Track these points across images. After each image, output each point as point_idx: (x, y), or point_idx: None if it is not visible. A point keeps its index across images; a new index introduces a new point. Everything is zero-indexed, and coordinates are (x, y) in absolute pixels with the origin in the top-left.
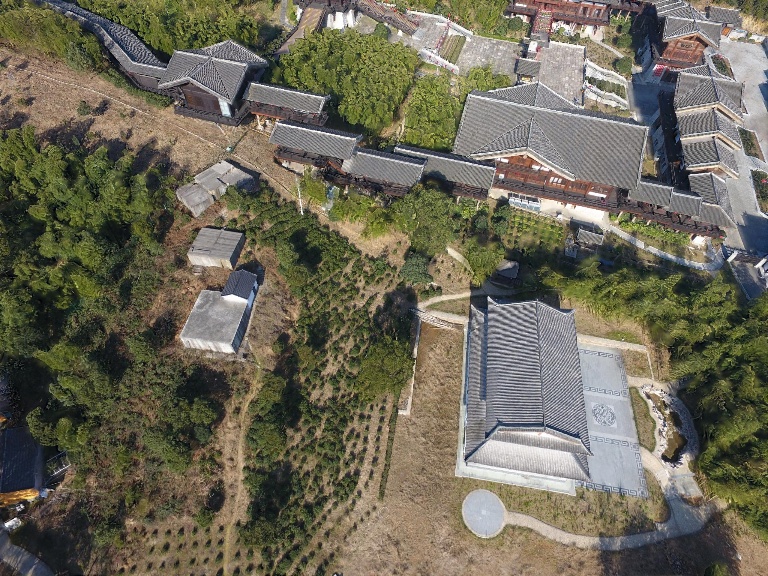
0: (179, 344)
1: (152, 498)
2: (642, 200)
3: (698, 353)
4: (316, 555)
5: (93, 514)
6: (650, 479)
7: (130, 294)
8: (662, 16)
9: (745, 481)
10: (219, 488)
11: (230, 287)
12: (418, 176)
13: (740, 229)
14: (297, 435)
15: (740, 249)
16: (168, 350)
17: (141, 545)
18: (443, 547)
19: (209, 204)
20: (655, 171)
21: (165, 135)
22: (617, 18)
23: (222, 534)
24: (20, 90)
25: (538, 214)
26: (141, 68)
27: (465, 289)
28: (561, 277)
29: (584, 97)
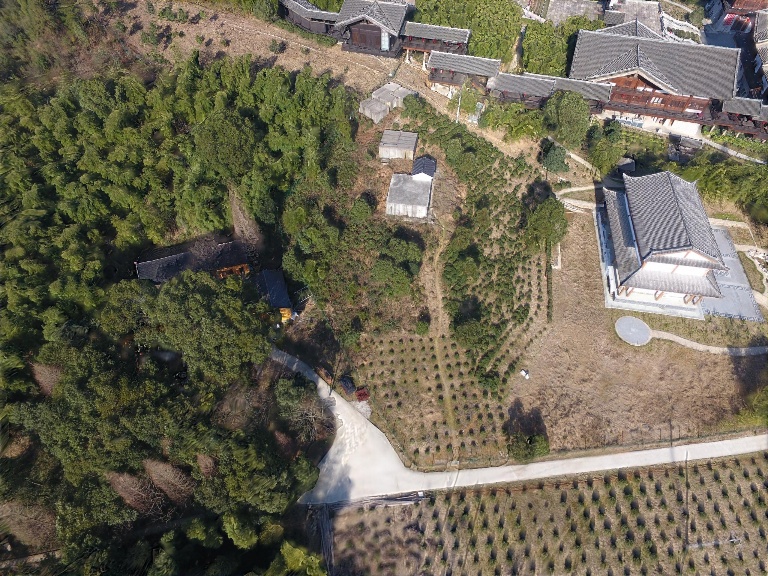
0: (381, 212)
1: (377, 318)
2: (735, 111)
3: None
4: (506, 357)
5: (334, 328)
6: (763, 311)
7: (336, 178)
8: None
9: None
10: (426, 311)
11: (418, 169)
12: (552, 89)
13: None
14: None
15: None
16: (374, 216)
17: (373, 350)
18: (604, 353)
19: (386, 114)
20: None
21: (337, 66)
22: None
23: (432, 343)
24: (218, 35)
25: (642, 129)
26: (315, 14)
27: (589, 183)
28: (676, 166)
29: None
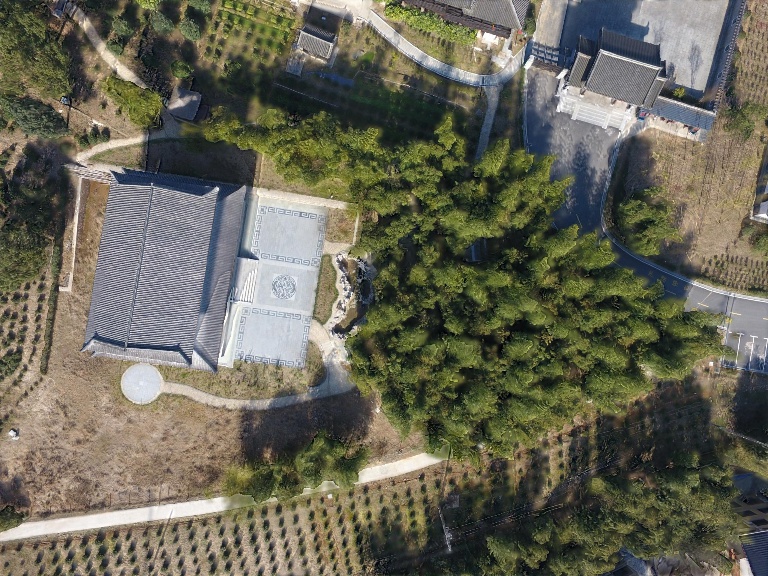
0: None
1: None
2: None
3: (383, 229)
4: None
5: None
6: (312, 350)
7: None
8: None
9: (365, 372)
10: None
11: None
12: None
13: (570, 9)
14: None
15: (552, 46)
16: None
17: None
18: (105, 410)
19: None
20: None
21: None
22: None
23: None
24: None
25: None
26: None
27: (141, 130)
28: (235, 126)
29: None
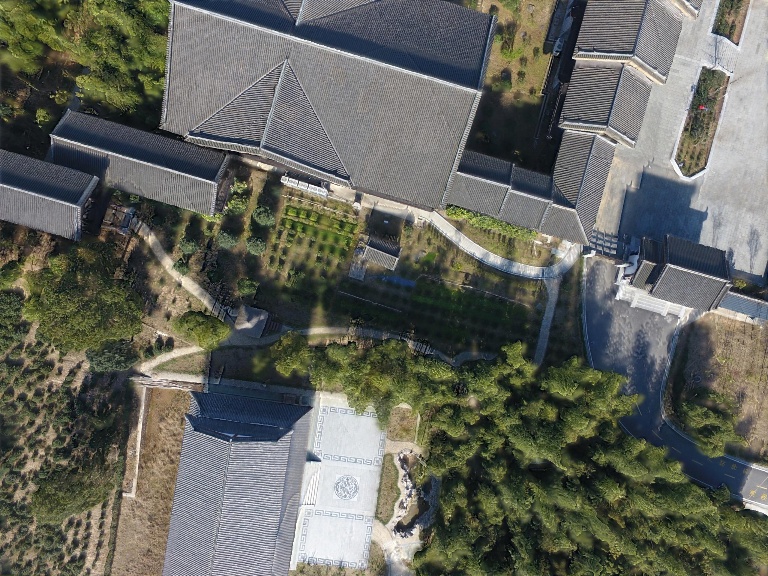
0: None
1: None
2: (461, 204)
3: (451, 448)
4: None
5: None
6: (375, 550)
7: None
8: None
9: None
10: None
11: None
12: (76, 222)
13: (628, 196)
14: (8, 533)
15: (611, 234)
16: None
17: None
18: None
19: None
20: (544, 81)
21: None
22: None
23: None
24: None
25: (321, 206)
26: None
27: None
28: (305, 355)
29: None
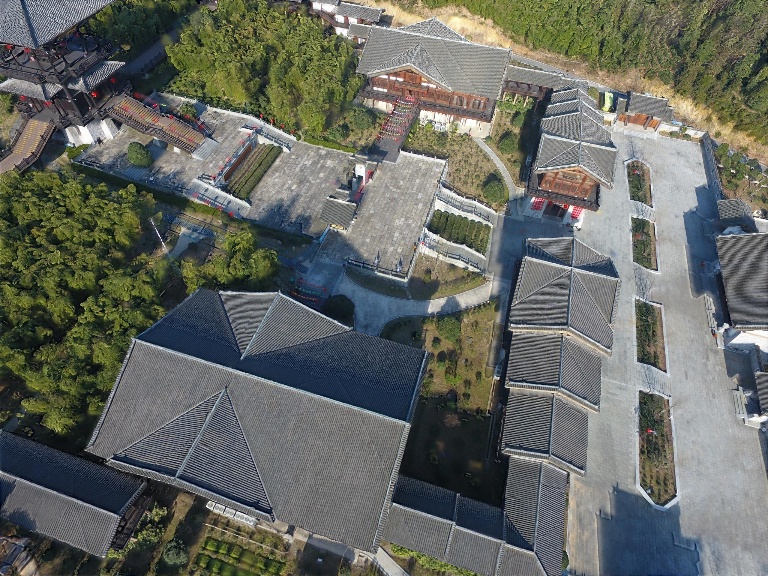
0: None
1: None
2: (401, 543)
3: None
4: None
5: None
6: None
7: None
8: (542, 129)
9: None
10: None
11: None
12: None
13: (601, 528)
14: None
15: None
16: None
17: None
18: None
19: None
20: (489, 402)
21: None
22: (514, 102)
23: None
24: None
25: None
26: None
27: None
28: None
29: (416, 256)
